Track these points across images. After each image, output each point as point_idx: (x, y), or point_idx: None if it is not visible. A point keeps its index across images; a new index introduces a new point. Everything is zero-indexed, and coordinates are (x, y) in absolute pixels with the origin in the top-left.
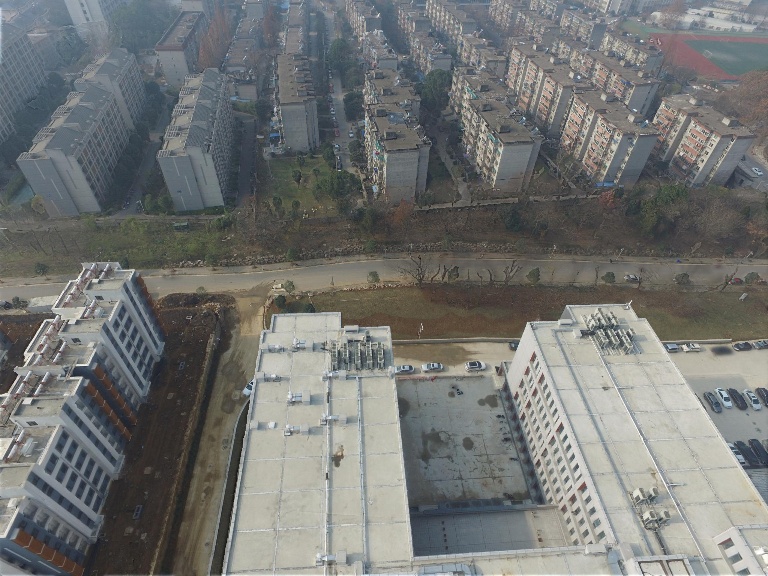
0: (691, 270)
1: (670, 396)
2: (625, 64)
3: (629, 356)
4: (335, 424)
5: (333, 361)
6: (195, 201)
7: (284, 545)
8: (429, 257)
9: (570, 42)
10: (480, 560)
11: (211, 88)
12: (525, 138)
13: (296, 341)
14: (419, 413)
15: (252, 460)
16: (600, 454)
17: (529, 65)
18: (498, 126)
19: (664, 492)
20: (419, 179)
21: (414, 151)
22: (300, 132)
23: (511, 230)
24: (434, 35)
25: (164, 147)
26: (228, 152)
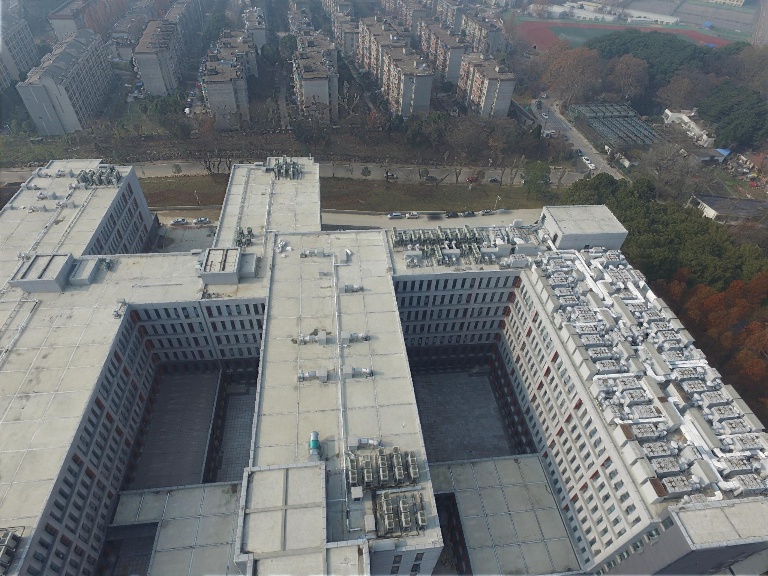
0: (443, 173)
1: (303, 197)
2: (450, 33)
3: (292, 180)
4: (66, 208)
5: (77, 177)
6: (56, 127)
7: (2, 253)
8: (233, 161)
9: (429, 21)
10: (122, 257)
11: (81, 43)
12: (322, 75)
13: (58, 170)
14: (179, 245)
15: (0, 221)
16: (234, 220)
17: (366, 32)
18: (303, 67)
19: (262, 234)
20: (241, 109)
21: (227, 83)
22: (156, 78)
23: (301, 142)
24: (308, 13)
25: (26, 81)
26: (97, 96)
